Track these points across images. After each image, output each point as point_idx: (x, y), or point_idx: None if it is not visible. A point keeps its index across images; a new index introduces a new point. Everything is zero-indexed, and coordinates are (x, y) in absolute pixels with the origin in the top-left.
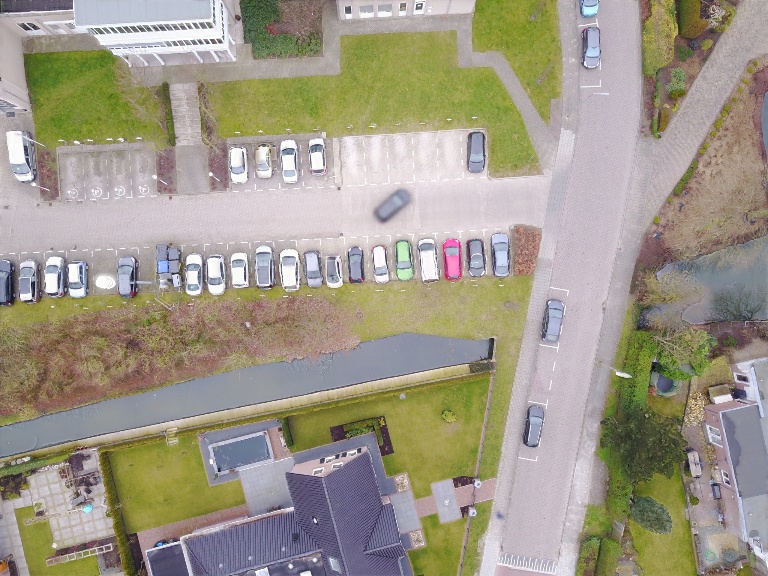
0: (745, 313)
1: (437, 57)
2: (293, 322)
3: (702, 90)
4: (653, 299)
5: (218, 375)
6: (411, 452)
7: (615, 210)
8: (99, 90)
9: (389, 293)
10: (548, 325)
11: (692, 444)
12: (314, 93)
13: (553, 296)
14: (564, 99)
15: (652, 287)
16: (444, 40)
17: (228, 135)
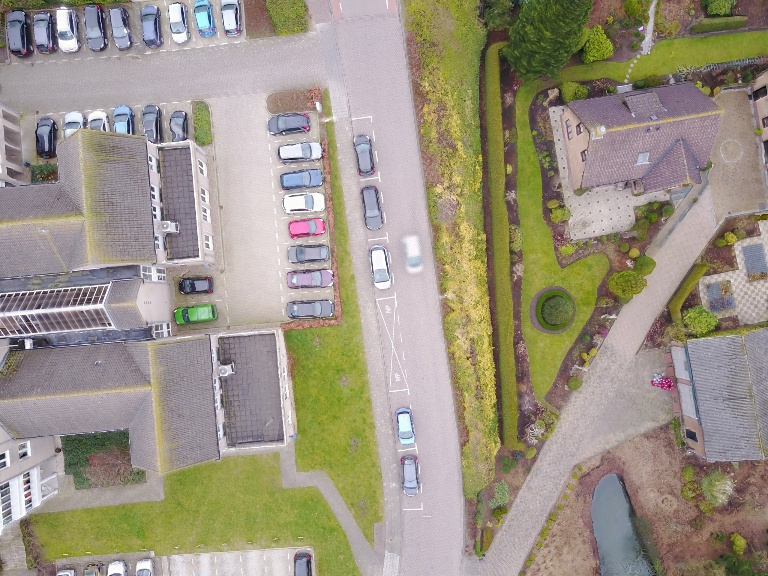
0: None
1: (261, 479)
2: None
3: (527, 501)
4: None
5: None
6: None
7: None
8: None
9: None
10: None
11: None
12: (139, 518)
13: None
14: (387, 523)
15: None
16: (267, 462)
17: (56, 557)
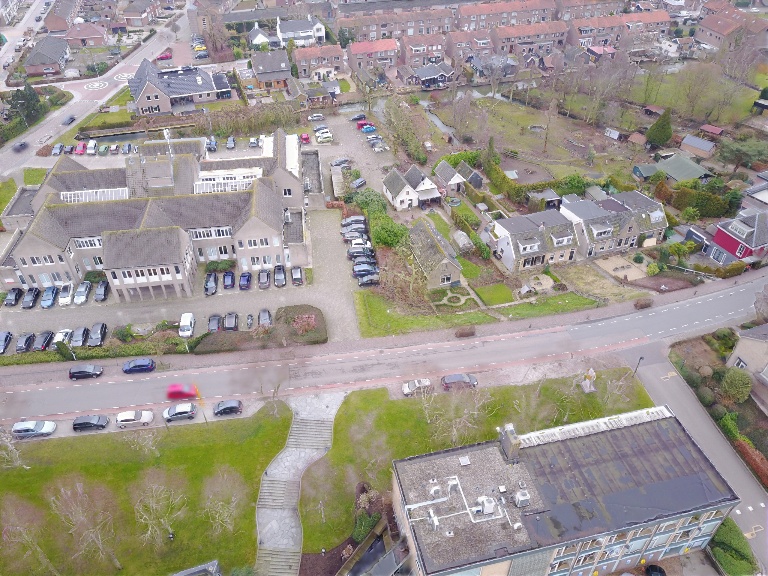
0: None
1: None
2: None
3: None
4: None
5: None
6: (123, 116)
7: None
8: None
9: None
10: None
11: (4, 121)
12: None
13: None
14: None
15: None
16: None
17: None
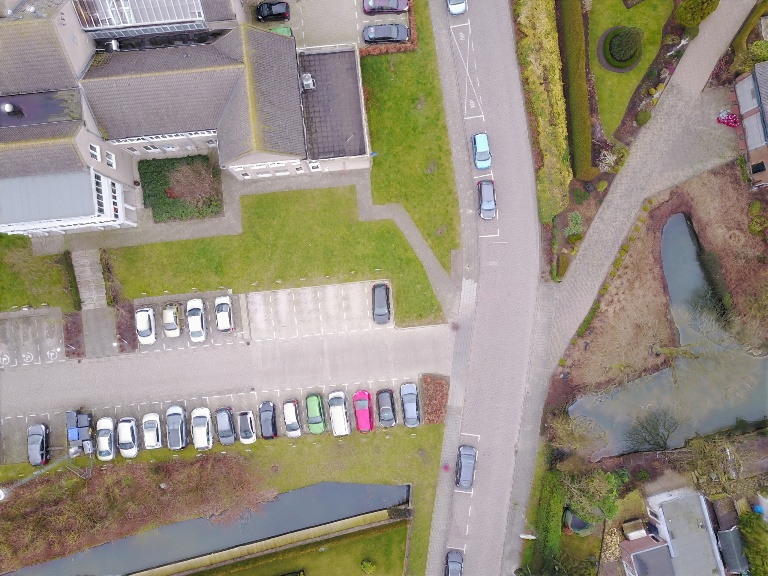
0: (662, 432)
1: (338, 212)
2: (207, 482)
3: (600, 231)
4: (560, 444)
5: (136, 535)
6: None
7: (520, 355)
8: (1, 261)
9: (303, 446)
10: (461, 471)
11: None
12: (217, 253)
13: (465, 442)
14: (464, 249)
15: (559, 432)
16: (344, 195)
17: (134, 296)
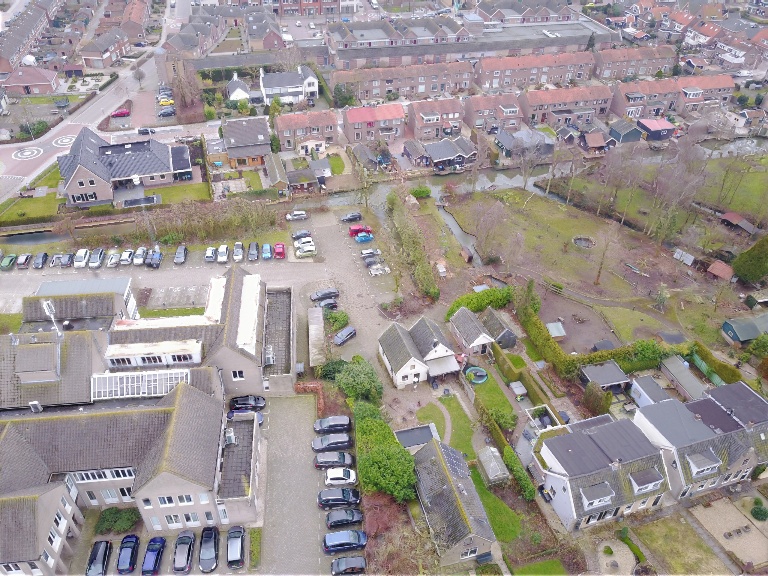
0: None
1: None
2: None
3: None
4: None
5: None
6: (50, 204)
7: None
8: None
9: None
10: None
11: None
12: None
13: None
14: None
15: None
16: None
17: None
